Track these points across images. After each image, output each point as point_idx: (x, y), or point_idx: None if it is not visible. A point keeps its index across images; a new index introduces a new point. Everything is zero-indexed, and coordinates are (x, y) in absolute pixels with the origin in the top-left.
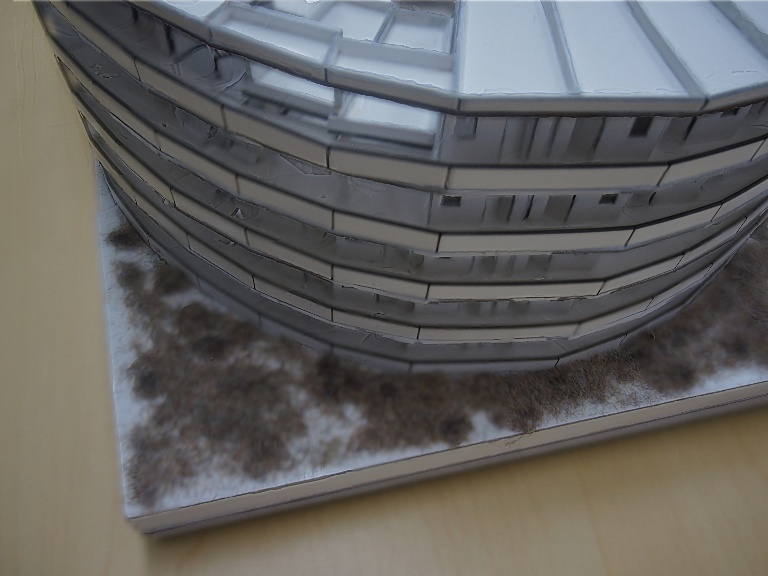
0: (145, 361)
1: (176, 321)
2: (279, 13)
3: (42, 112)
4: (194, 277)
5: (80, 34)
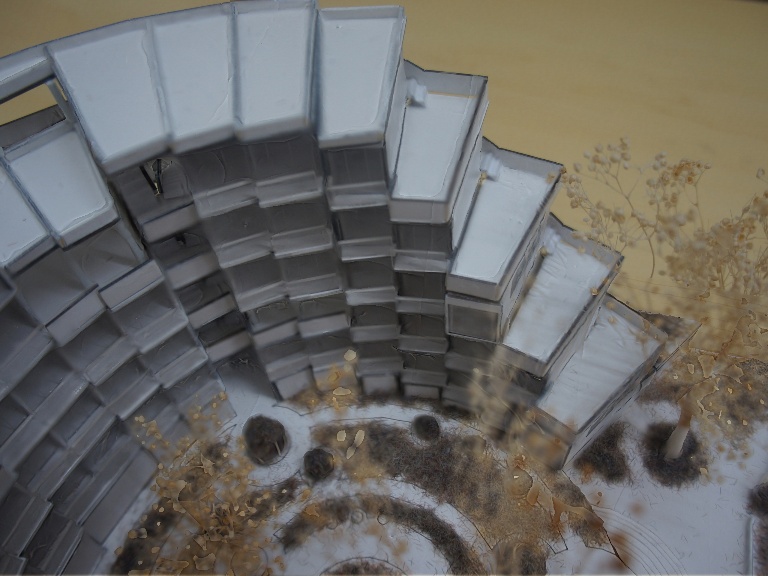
0: None
1: None
2: (11, 77)
3: None
4: None
5: None
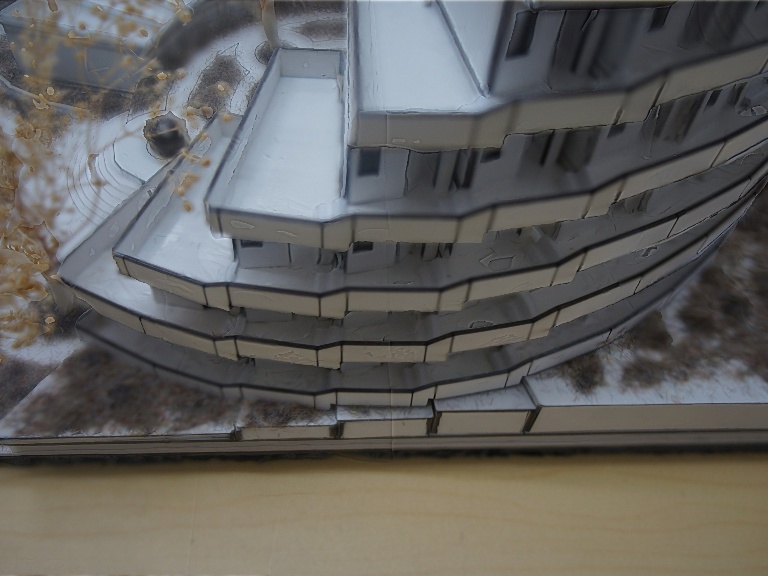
0: (759, 367)
1: (705, 334)
2: None
3: (151, 564)
4: (667, 297)
5: (767, 73)
